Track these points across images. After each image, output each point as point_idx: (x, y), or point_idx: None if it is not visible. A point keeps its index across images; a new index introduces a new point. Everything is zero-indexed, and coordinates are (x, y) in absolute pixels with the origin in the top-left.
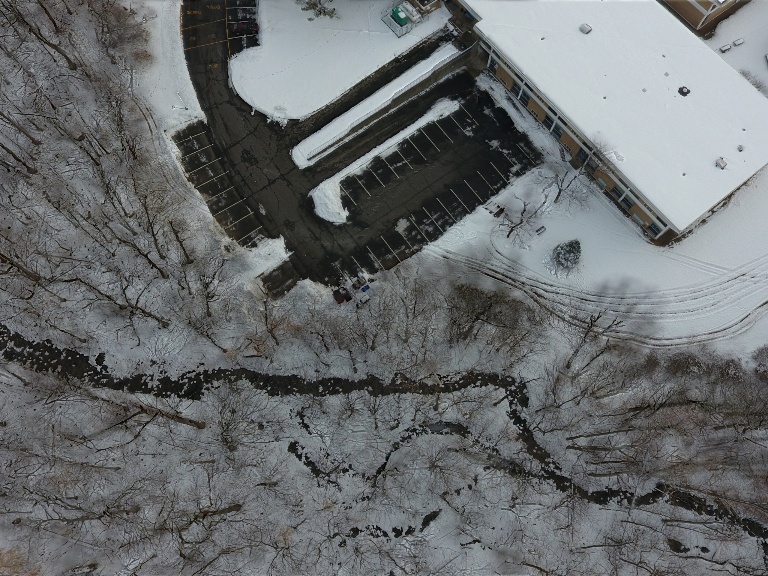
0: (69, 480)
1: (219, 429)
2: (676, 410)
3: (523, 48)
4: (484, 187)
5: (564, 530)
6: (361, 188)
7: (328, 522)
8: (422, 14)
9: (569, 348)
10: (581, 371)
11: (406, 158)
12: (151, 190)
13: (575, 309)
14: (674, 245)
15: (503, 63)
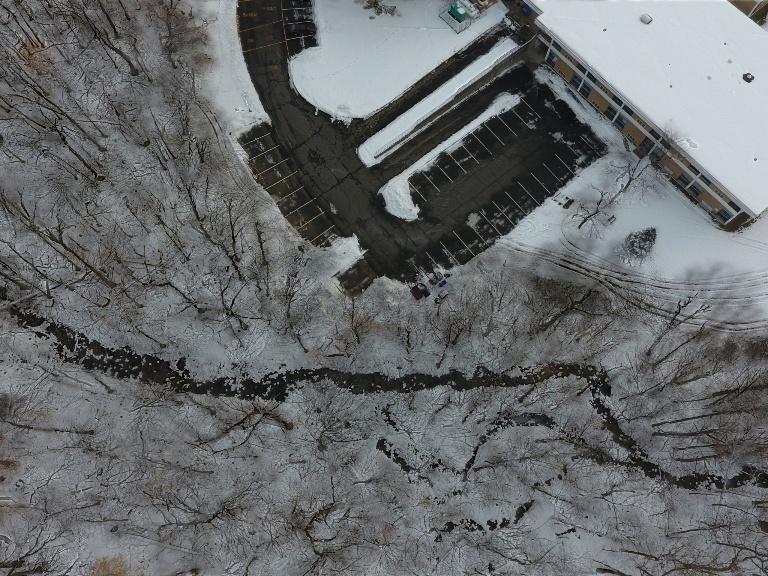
0: (164, 486)
1: (307, 429)
2: (757, 393)
3: (586, 40)
4: (551, 179)
5: (660, 516)
6: (430, 184)
7: (423, 518)
8: (480, 9)
9: (651, 335)
10: (661, 358)
11: (472, 153)
12: (222, 193)
13: (650, 297)
14: (743, 230)
15: (564, 56)
